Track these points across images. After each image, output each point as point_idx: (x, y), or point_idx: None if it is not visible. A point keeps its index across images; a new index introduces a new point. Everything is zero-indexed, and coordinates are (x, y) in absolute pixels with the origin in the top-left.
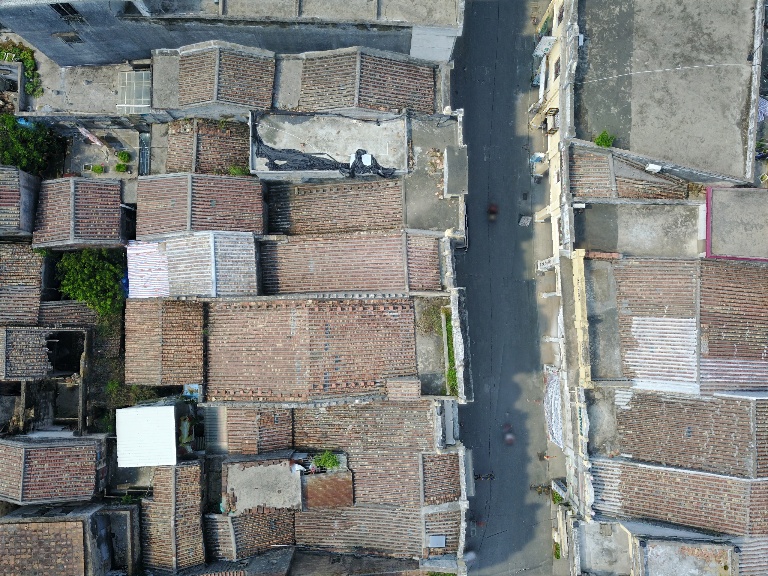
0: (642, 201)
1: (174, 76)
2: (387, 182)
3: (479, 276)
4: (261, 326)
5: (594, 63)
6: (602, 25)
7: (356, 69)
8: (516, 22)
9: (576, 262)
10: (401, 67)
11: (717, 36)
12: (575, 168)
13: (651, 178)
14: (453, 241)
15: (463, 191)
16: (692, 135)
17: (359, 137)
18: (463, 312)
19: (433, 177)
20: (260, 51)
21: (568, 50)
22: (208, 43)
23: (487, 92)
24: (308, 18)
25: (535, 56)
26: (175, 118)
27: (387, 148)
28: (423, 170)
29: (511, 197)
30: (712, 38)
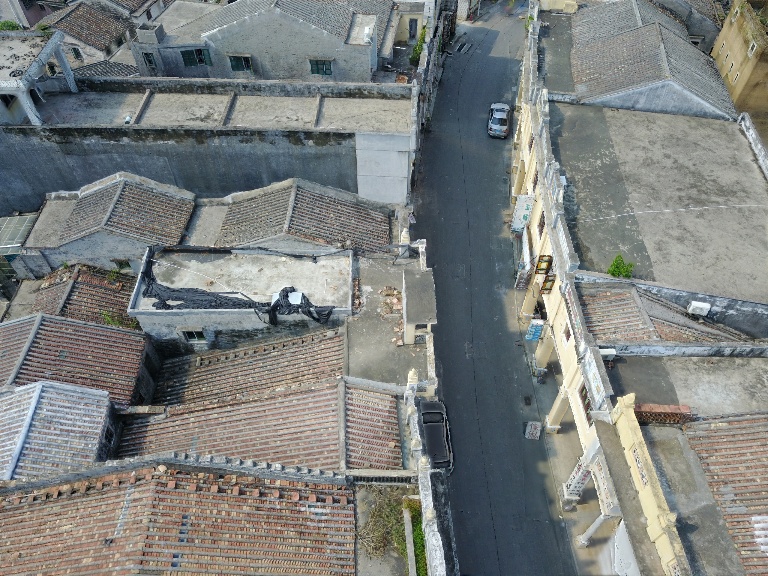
0: (699, 344)
1: (65, 218)
2: (324, 333)
3: (474, 513)
4: (67, 527)
5: (584, 205)
6: (585, 174)
7: (289, 200)
8: (489, 226)
9: (623, 421)
10: (347, 207)
11: (724, 182)
12: (589, 312)
13: (700, 327)
14: (429, 452)
15: (430, 320)
16: (737, 272)
17: (288, 275)
18: (443, 511)
19: (388, 320)
20: (176, 190)
21: (550, 193)
22: (113, 177)
23: (463, 287)
24: (230, 126)
25: (513, 231)
26: (54, 268)
27: (325, 286)
28: (374, 311)
29: (508, 402)
30: (719, 183)
